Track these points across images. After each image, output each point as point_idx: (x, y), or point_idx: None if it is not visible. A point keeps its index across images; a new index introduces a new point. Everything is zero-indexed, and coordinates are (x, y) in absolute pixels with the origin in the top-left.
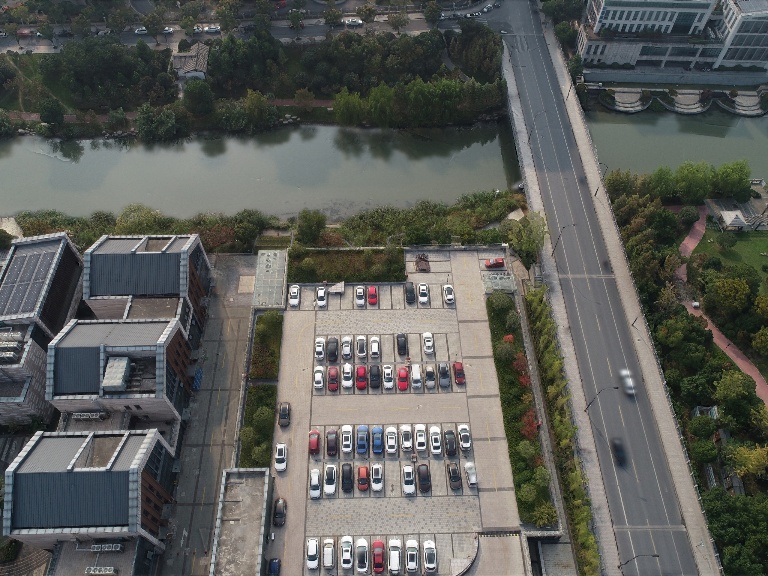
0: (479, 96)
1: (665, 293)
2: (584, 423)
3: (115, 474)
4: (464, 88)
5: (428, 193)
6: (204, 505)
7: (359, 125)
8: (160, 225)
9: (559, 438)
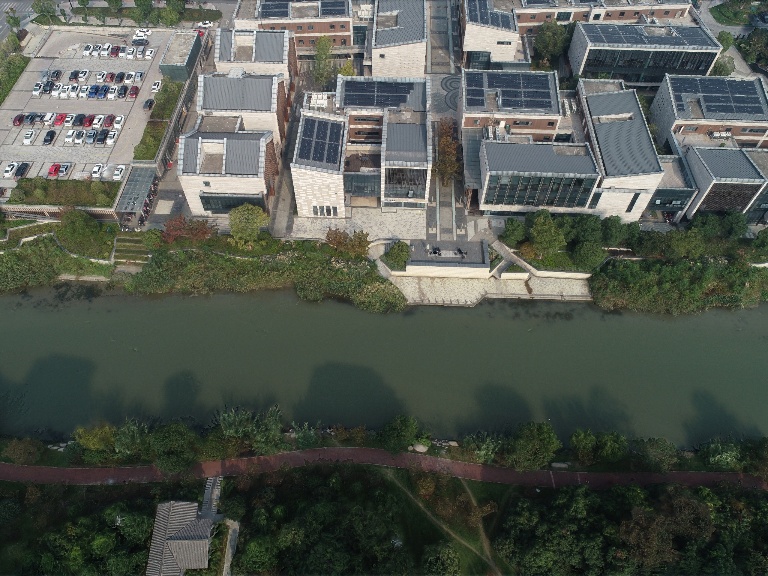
0: None
1: None
2: None
3: None
4: None
5: None
6: None
7: None
8: None
9: None
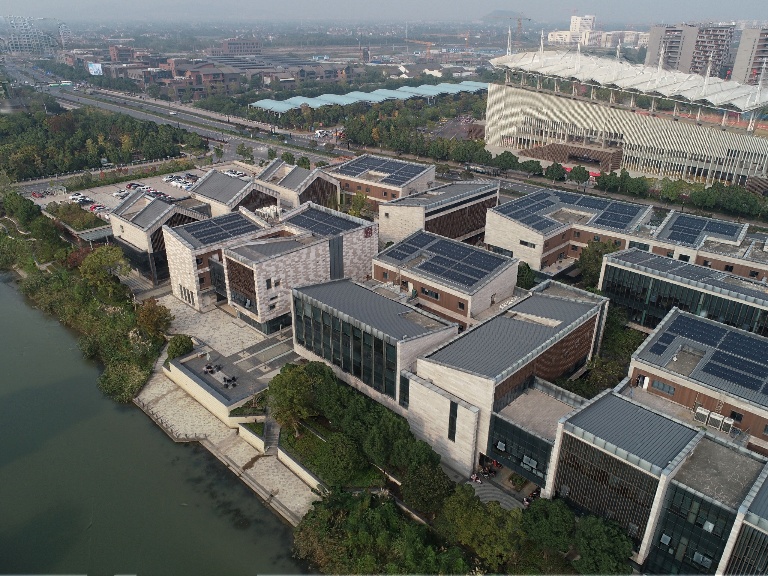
0: None
1: None
2: None
3: None
4: None
5: None
6: None
7: None
8: None
9: None
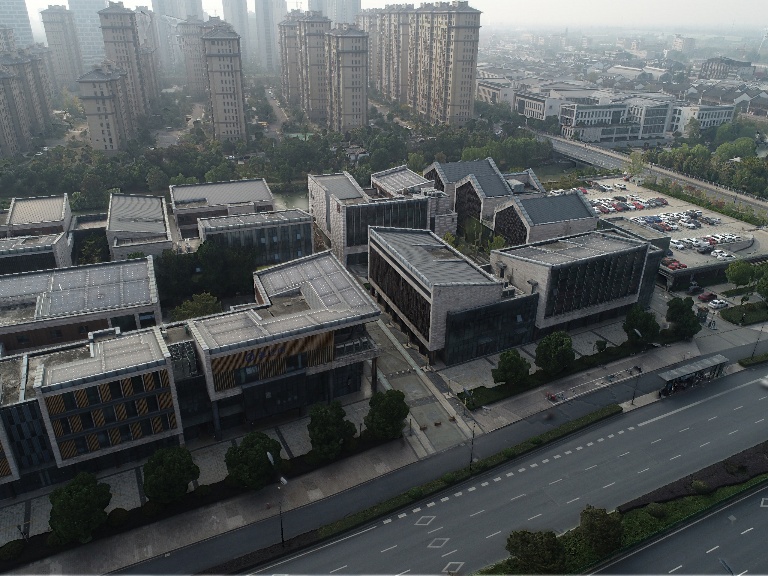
0: (541, 147)
1: None
2: None
3: (569, 196)
4: (532, 143)
5: None
6: None
7: None
8: None
9: None
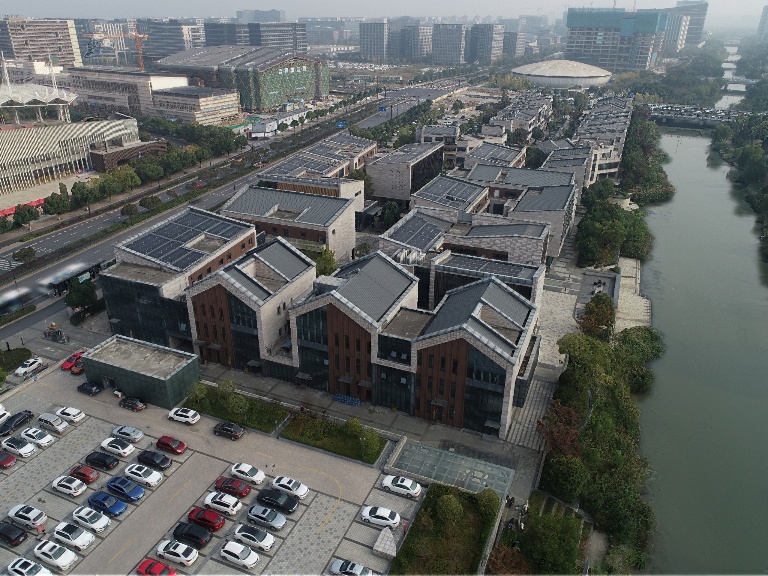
0: None
1: None
2: None
3: None
4: None
5: None
6: None
7: None
8: (623, 417)
9: None
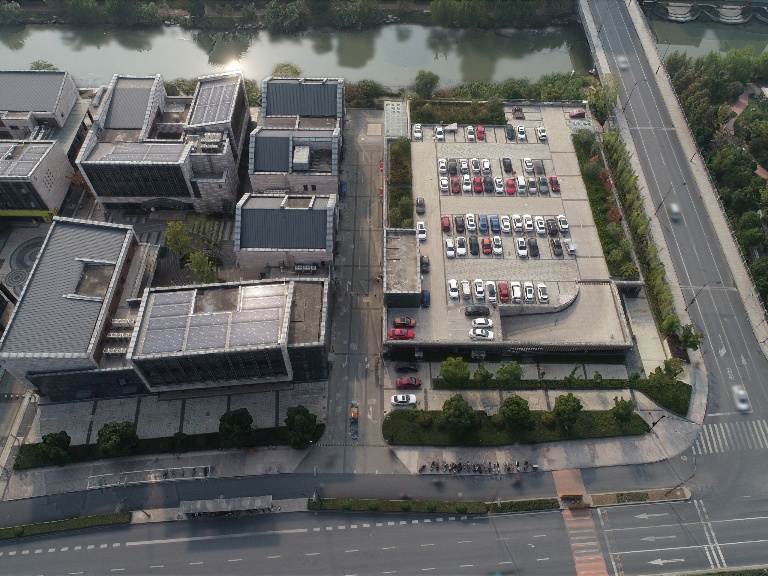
0: (555, 0)
1: (719, 133)
2: (655, 222)
3: (315, 212)
4: None
5: (513, 75)
6: (361, 267)
7: (450, 25)
8: None
9: (636, 229)
